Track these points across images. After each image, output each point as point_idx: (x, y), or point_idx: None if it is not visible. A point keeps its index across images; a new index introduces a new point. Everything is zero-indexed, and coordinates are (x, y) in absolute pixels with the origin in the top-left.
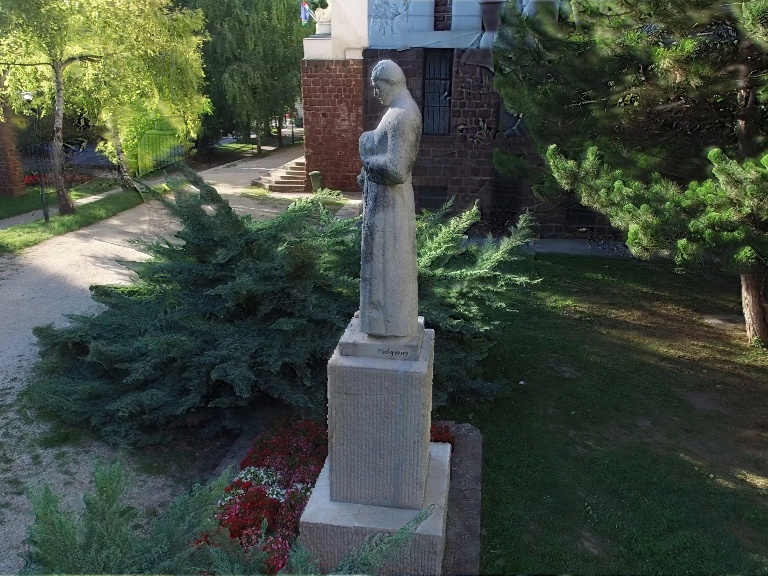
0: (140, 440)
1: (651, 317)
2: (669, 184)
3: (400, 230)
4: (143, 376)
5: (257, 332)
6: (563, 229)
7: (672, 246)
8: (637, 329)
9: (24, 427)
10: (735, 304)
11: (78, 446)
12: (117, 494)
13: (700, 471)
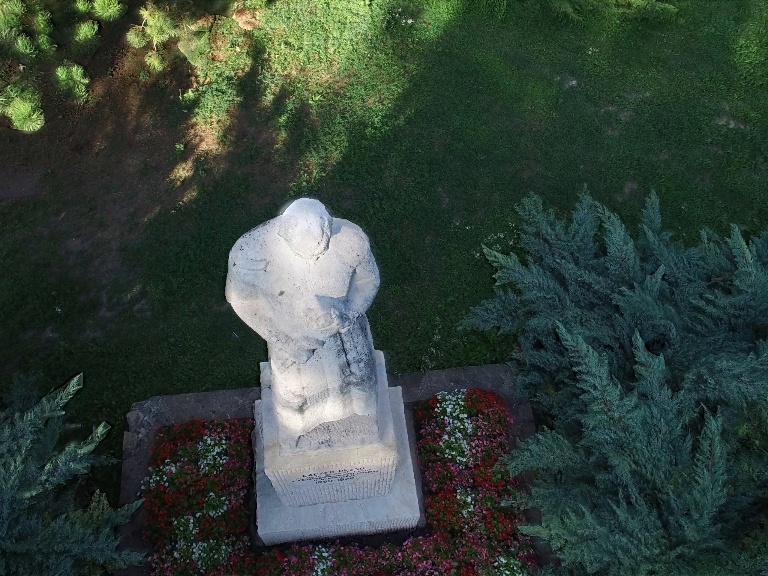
0: None
1: None
2: None
3: None
4: None
5: None
6: None
7: None
8: None
9: None
10: None
11: None
12: None
13: (177, 210)
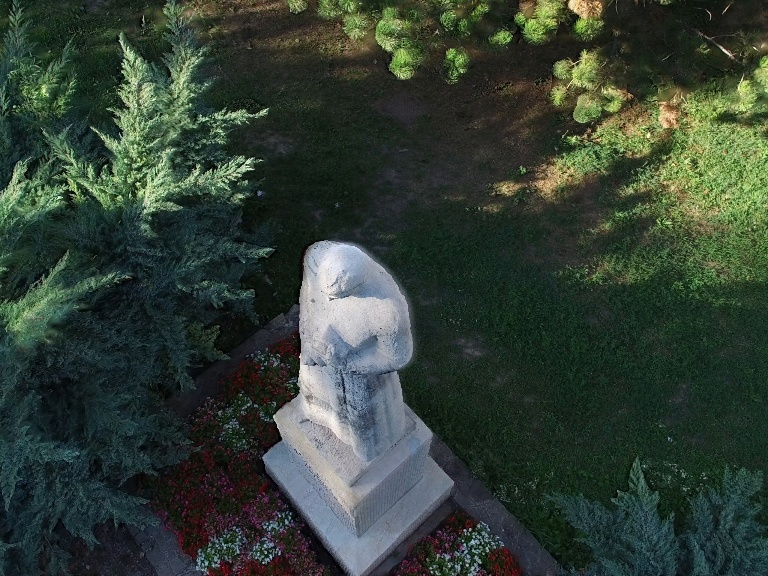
0: None
1: None
2: None
3: None
4: None
5: (51, 437)
6: None
7: (422, 42)
8: (270, 21)
9: None
10: None
11: None
12: None
13: (471, 210)
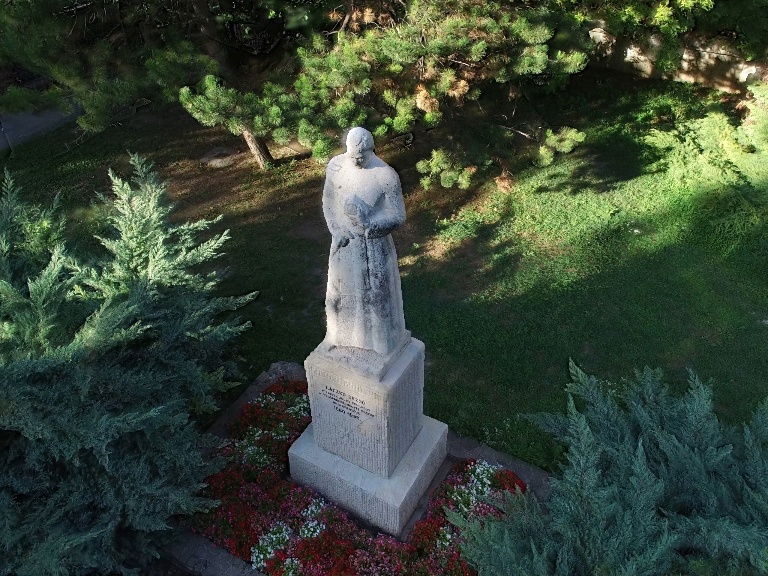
0: None
1: None
2: (277, 88)
3: None
4: None
5: None
6: None
7: None
8: None
9: None
10: (202, 138)
11: None
12: None
13: None
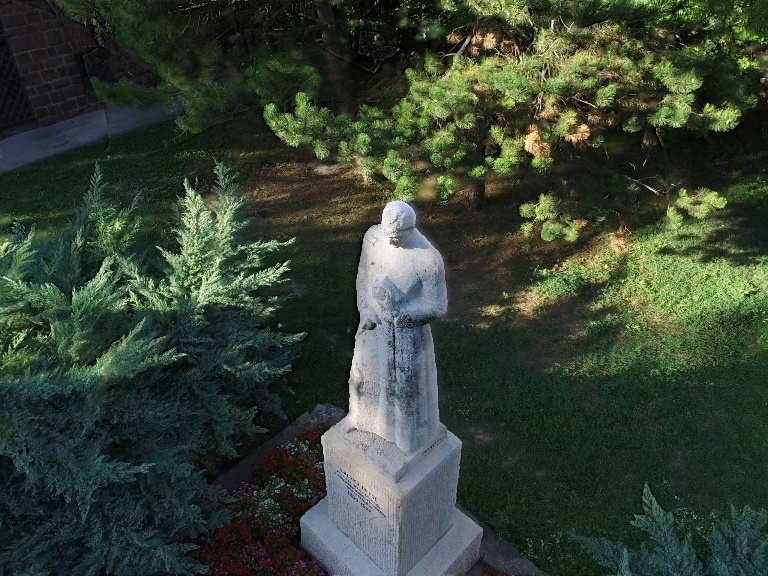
0: None
1: (277, 186)
2: (373, 111)
3: None
4: None
5: (109, 493)
6: (87, 100)
7: None
8: (282, 206)
9: None
10: None
11: None
12: None
13: (466, 327)
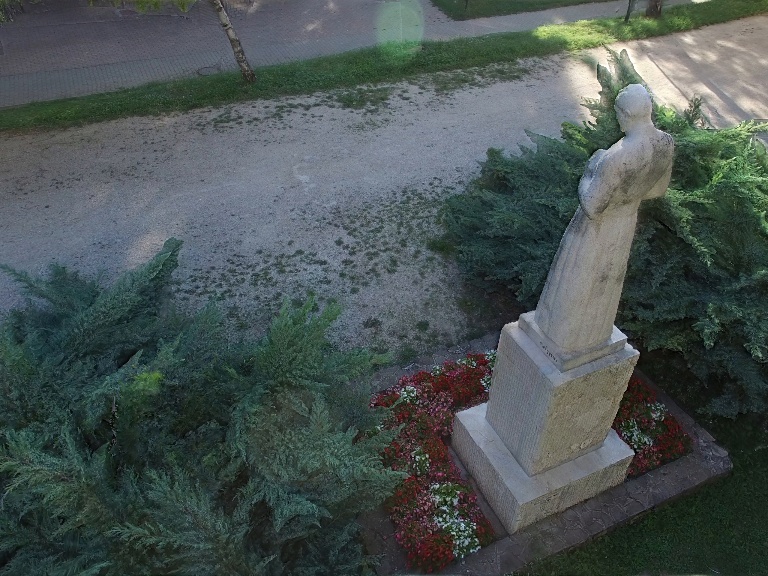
0: (473, 280)
1: None
2: None
3: (582, 258)
4: (494, 235)
5: None
6: None
7: None
8: None
9: (433, 225)
10: None
11: (445, 259)
12: (325, 326)
13: None
